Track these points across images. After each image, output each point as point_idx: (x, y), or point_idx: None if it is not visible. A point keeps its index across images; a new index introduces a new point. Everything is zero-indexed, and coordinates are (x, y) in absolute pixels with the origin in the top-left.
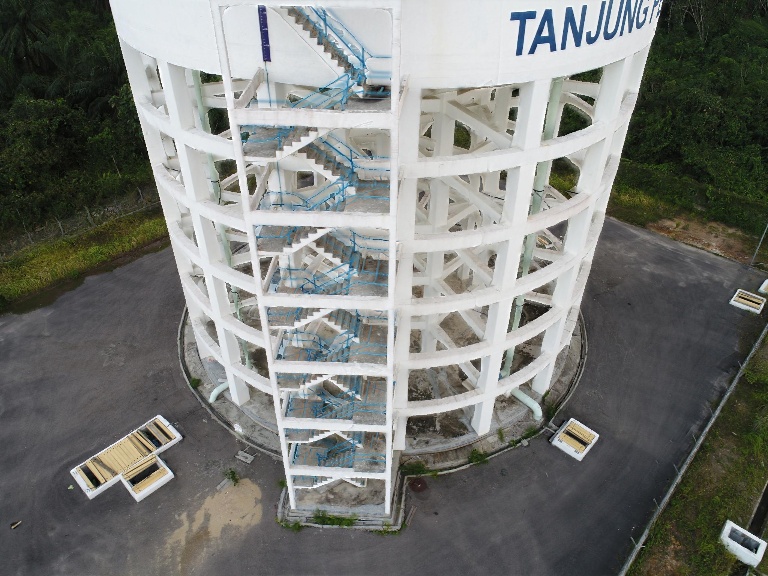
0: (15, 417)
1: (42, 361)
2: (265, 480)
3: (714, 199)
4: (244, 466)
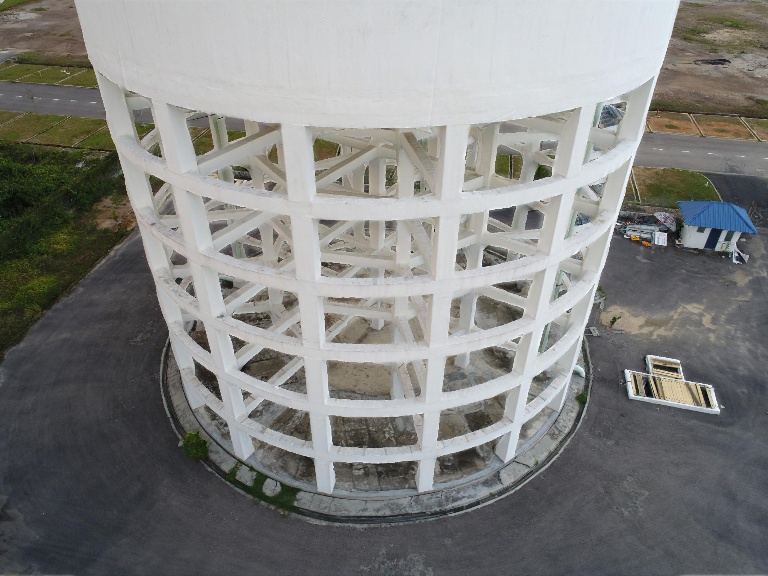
0: (760, 511)
1: (714, 567)
2: (594, 316)
3: (77, 193)
4: (599, 329)
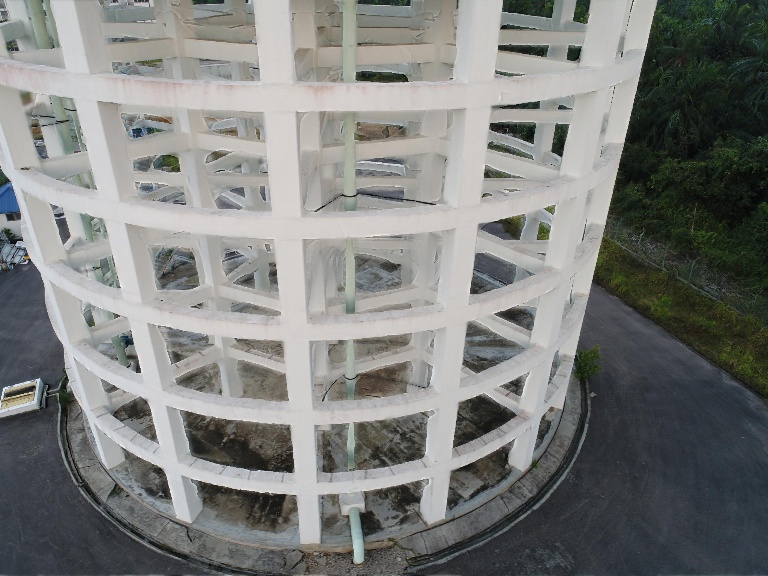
0: None
1: None
2: None
3: None
4: None
